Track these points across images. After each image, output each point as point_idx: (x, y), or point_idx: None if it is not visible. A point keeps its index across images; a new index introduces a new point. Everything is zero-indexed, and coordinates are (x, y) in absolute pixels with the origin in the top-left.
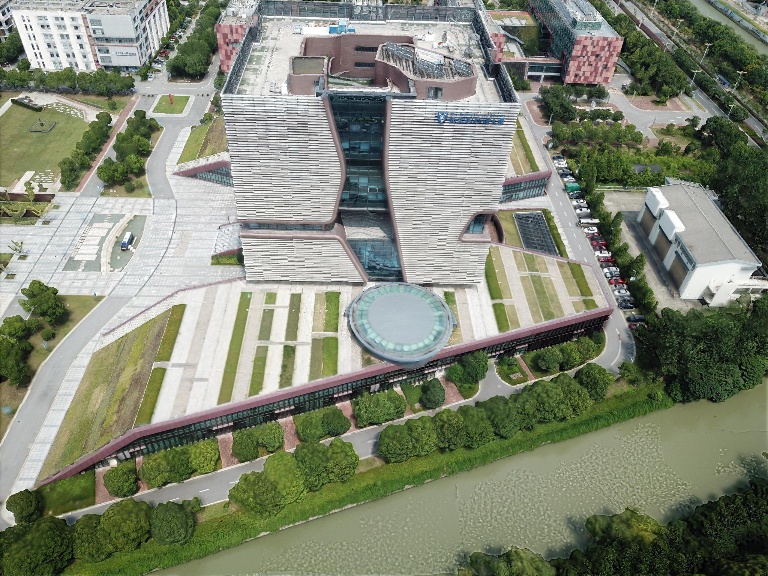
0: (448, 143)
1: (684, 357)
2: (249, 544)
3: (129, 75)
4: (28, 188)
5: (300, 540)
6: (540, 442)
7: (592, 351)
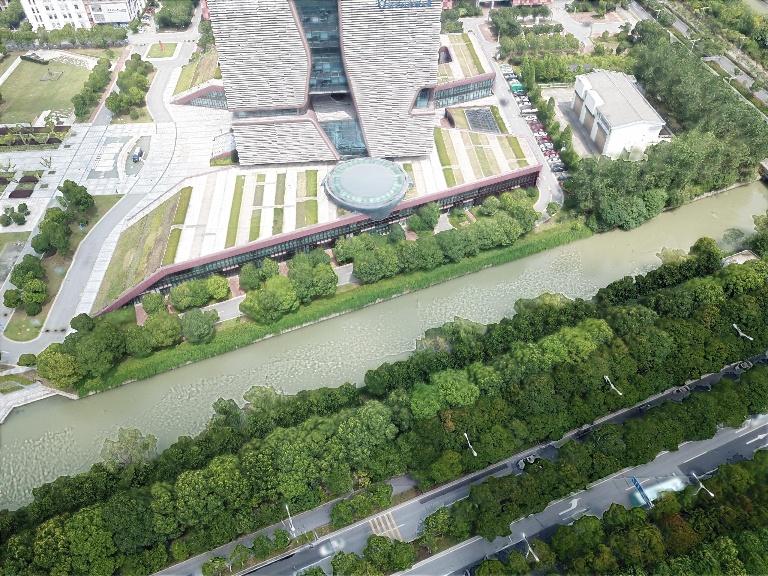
0: (389, 26)
1: (597, 193)
2: (258, 344)
3: (122, 28)
4: (47, 122)
5: (298, 344)
6: (483, 264)
7: (524, 198)
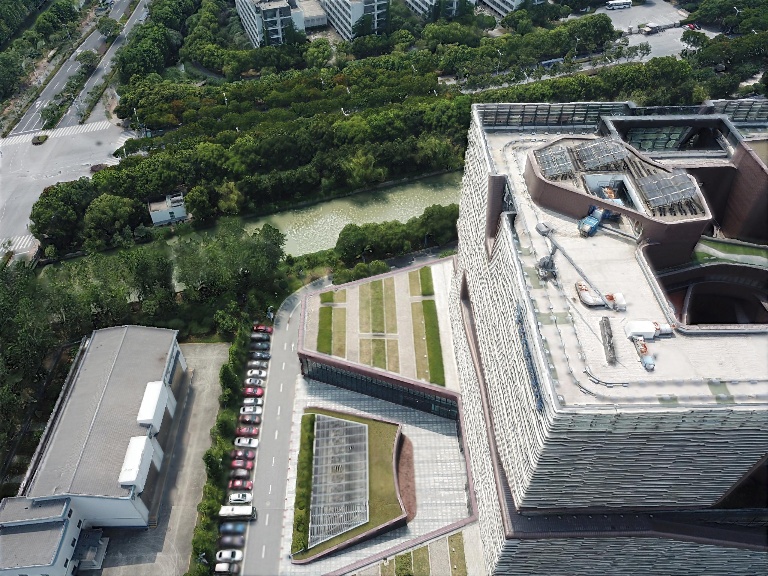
0: None
1: None
2: None
3: None
4: None
5: None
6: None
7: None
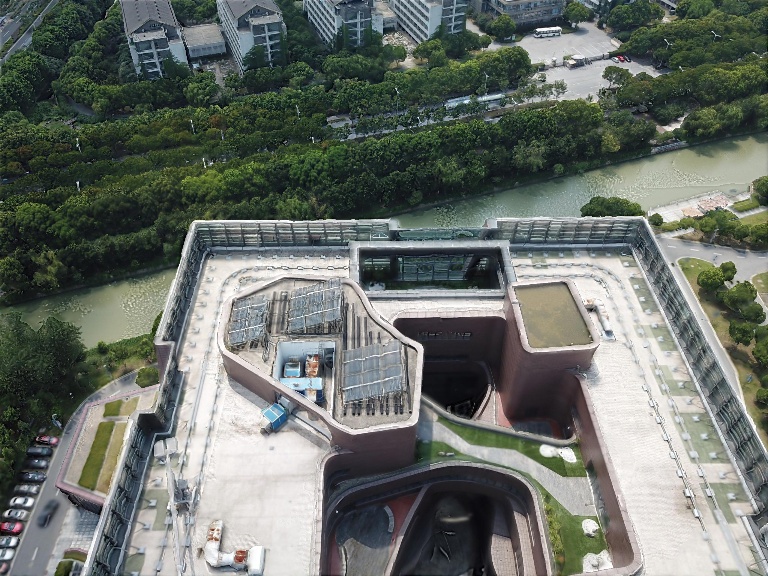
0: None
1: None
2: None
3: None
4: None
5: None
6: None
7: None
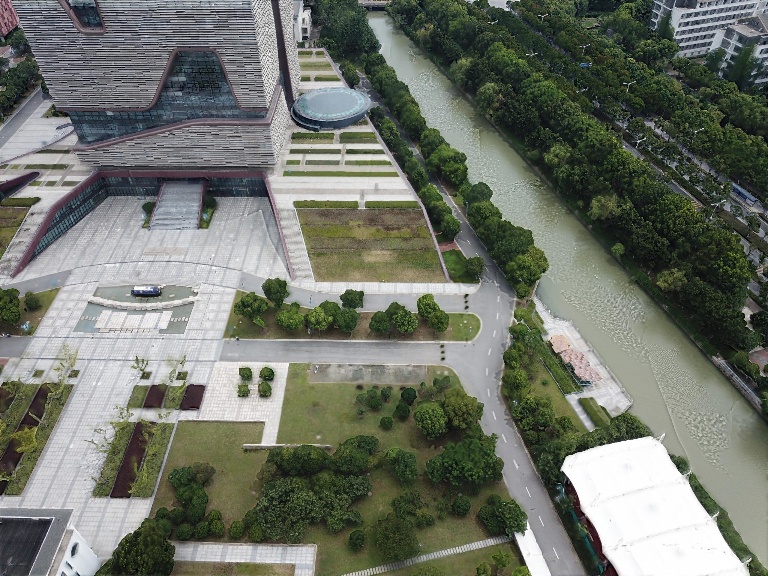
0: None
1: None
2: None
3: None
4: None
5: None
6: None
7: None
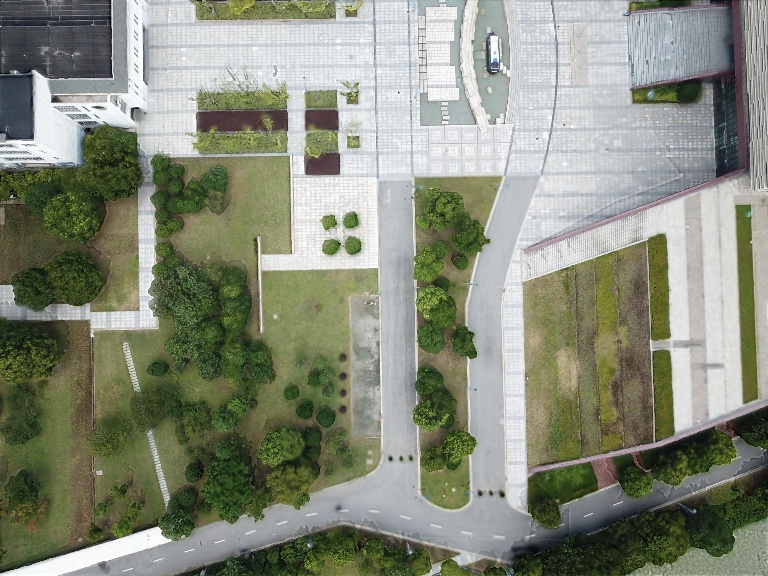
0: None
1: None
2: None
3: None
4: None
5: None
6: None
7: None
